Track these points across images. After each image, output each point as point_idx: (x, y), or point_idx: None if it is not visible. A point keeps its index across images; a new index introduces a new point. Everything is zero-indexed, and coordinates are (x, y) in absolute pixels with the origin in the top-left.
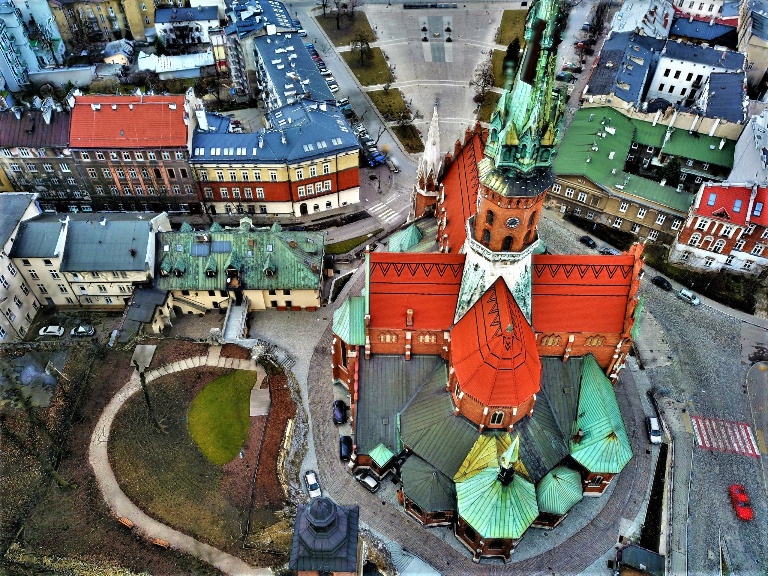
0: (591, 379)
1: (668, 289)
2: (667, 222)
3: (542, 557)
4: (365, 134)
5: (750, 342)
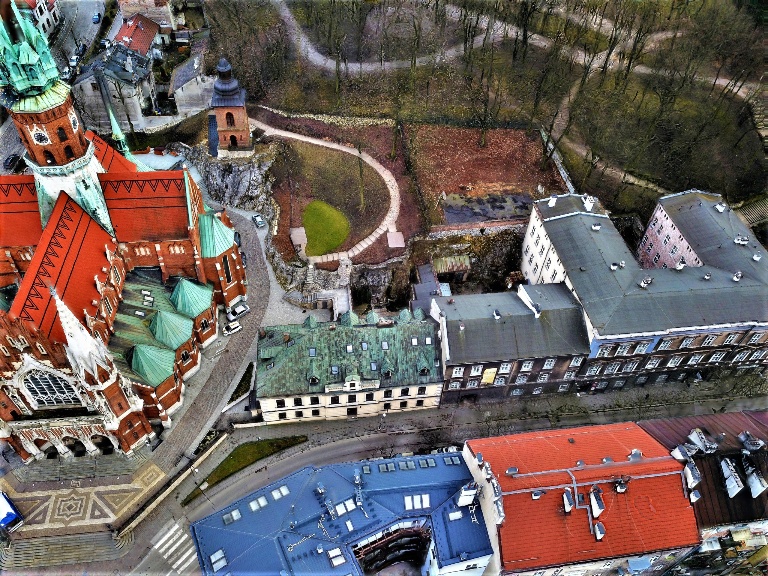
0: None
1: None
2: None
3: None
4: None
5: None
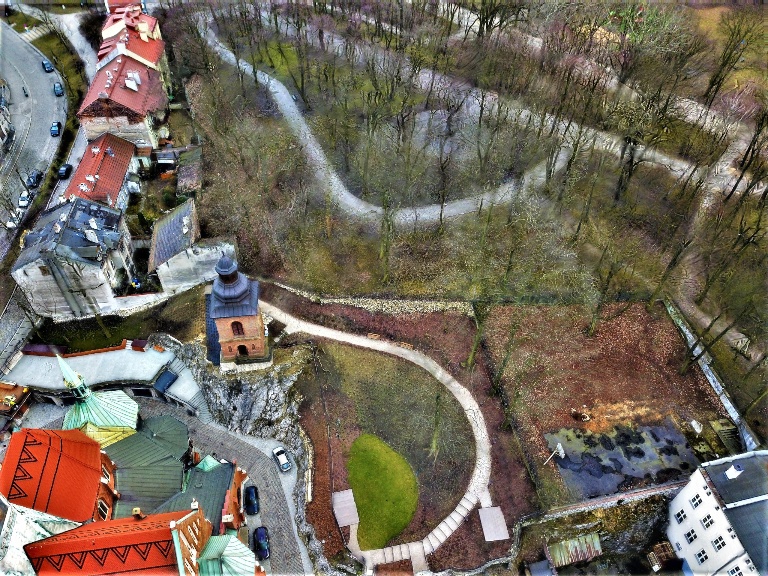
0: None
1: None
2: None
3: None
4: None
5: None
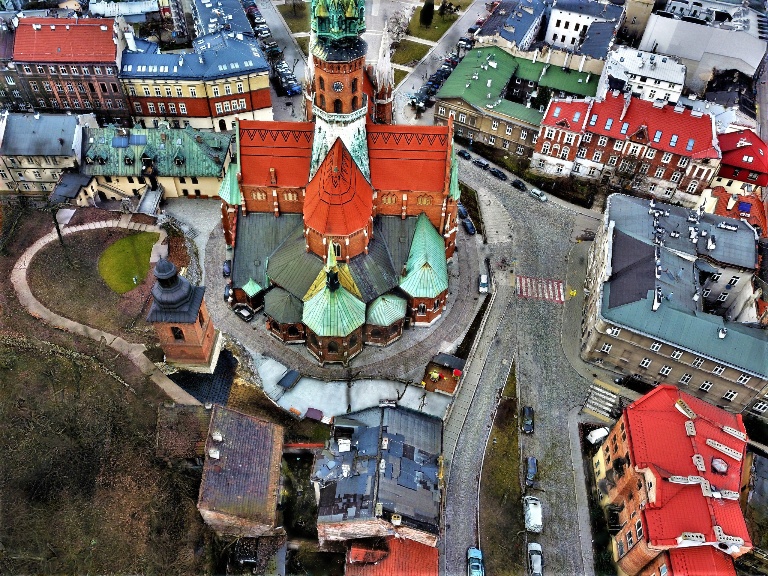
0: (420, 230)
1: (523, 189)
2: (529, 137)
3: (374, 365)
4: (287, 70)
5: (581, 227)
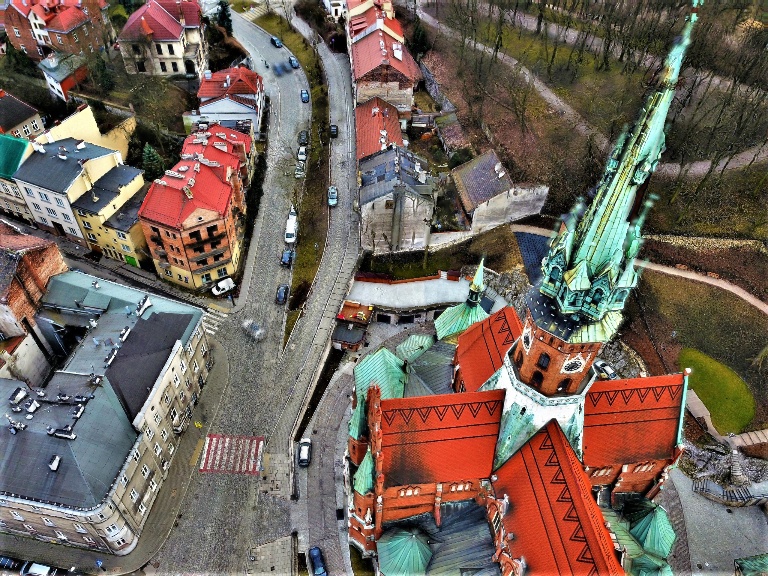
0: None
1: None
2: None
3: None
4: None
5: None
